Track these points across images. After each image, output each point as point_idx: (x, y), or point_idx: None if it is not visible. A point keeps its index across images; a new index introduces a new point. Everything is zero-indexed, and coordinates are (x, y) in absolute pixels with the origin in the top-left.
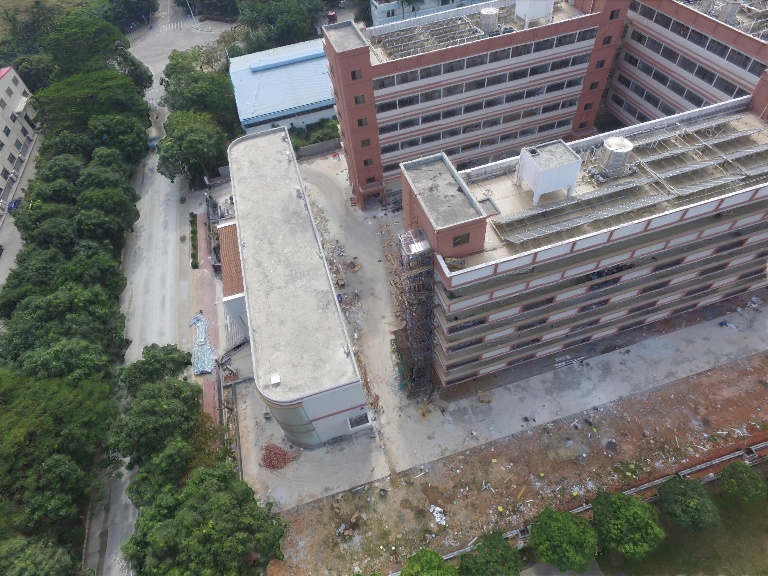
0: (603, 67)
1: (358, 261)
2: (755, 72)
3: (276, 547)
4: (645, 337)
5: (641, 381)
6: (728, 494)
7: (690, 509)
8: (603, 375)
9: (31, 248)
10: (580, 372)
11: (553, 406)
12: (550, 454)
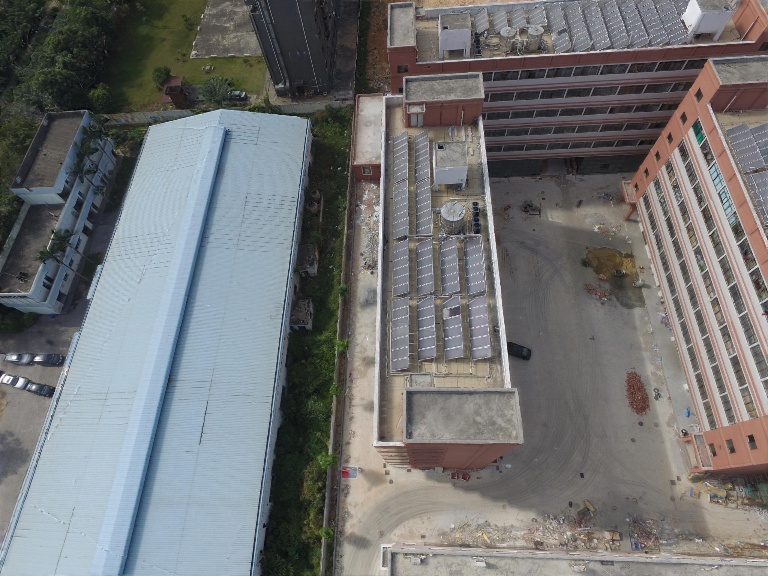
0: None
1: (576, 502)
2: (607, 72)
3: None
4: None
5: None
6: None
7: None
8: None
9: None
10: None
11: None
12: None
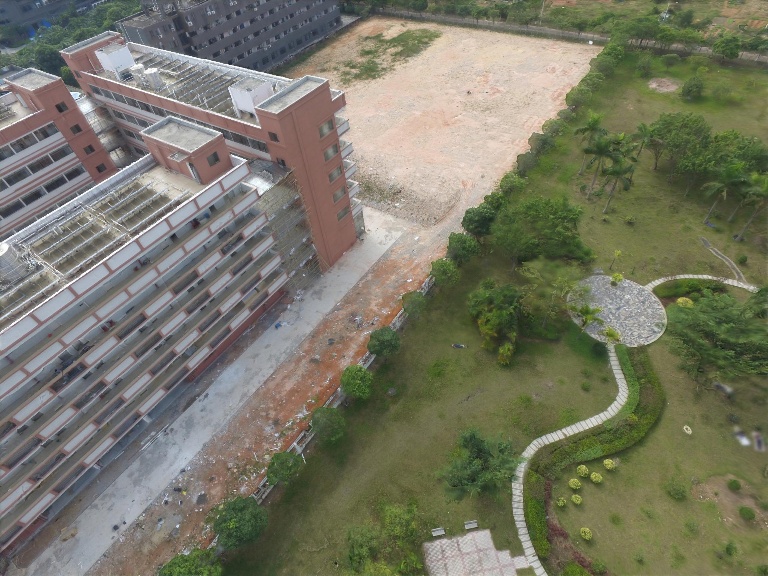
0: (95, 151)
1: None
2: None
3: None
4: (219, 373)
5: (220, 417)
6: (295, 479)
7: (231, 531)
8: (187, 432)
9: None
10: (165, 442)
11: (142, 495)
12: (144, 549)
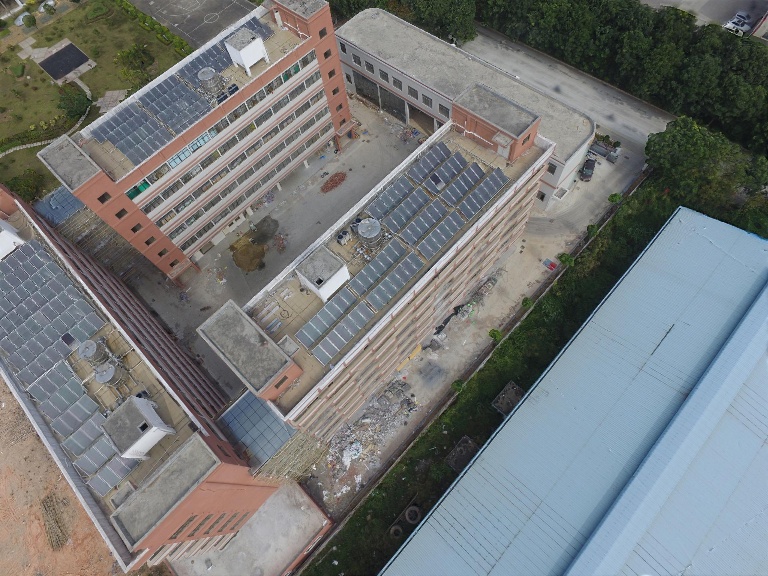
0: None
1: None
2: (96, 289)
3: (338, 0)
4: None
5: None
6: None
7: None
8: None
9: (634, 5)
10: None
11: None
12: None
